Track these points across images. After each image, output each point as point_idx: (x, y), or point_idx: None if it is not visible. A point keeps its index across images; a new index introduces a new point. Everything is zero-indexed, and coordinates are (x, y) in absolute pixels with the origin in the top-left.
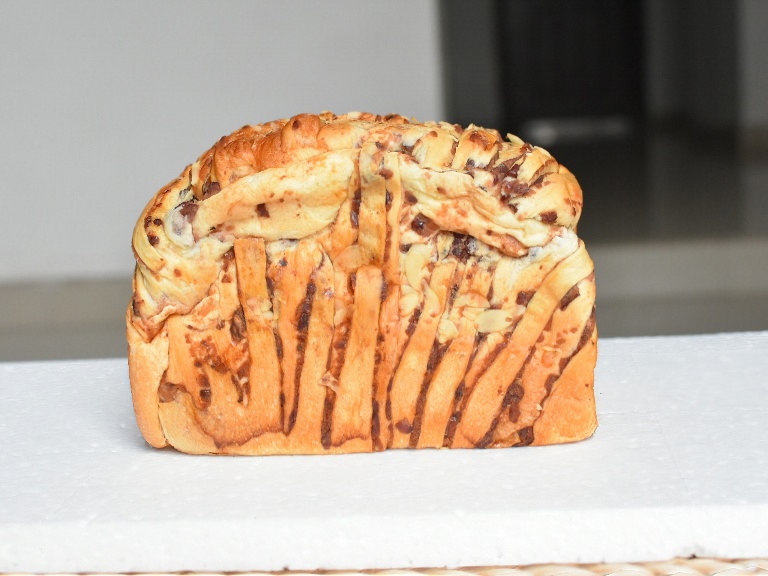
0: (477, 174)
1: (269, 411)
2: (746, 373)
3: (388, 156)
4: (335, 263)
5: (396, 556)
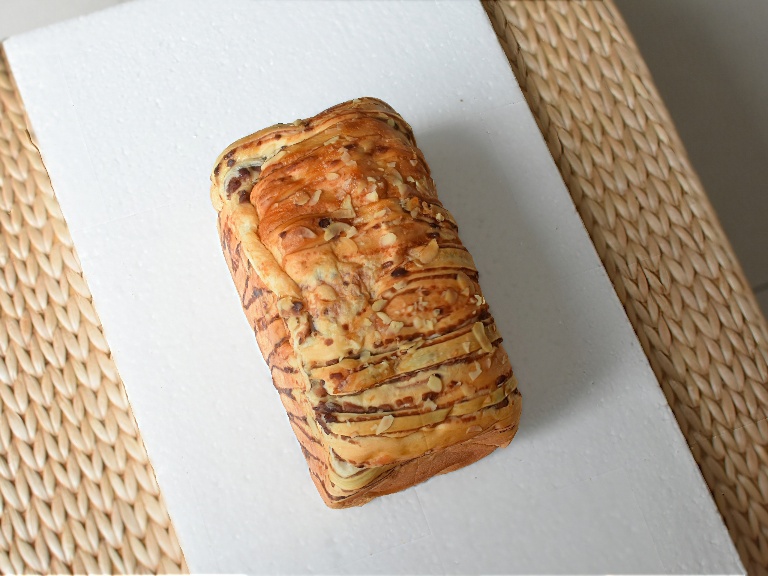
0: (311, 393)
1: None
2: None
3: (290, 320)
4: None
5: None
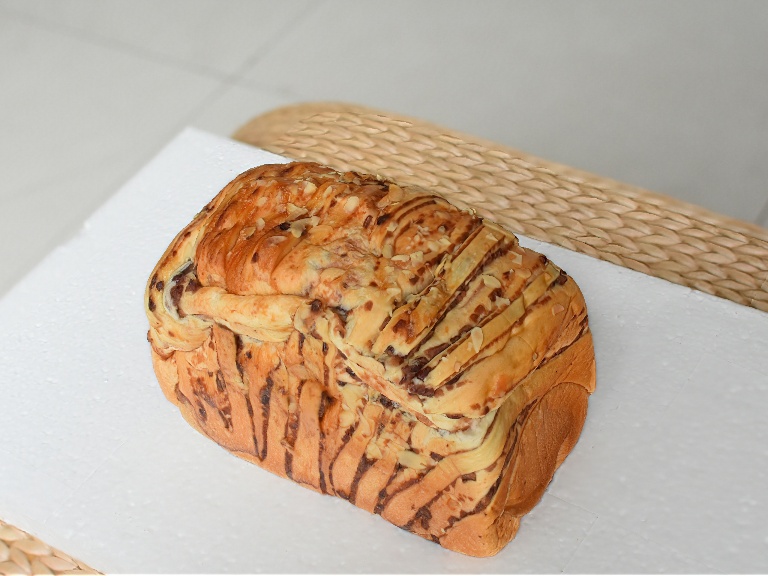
0: (388, 369)
1: (247, 442)
2: (760, 460)
3: (318, 323)
4: (289, 370)
5: None
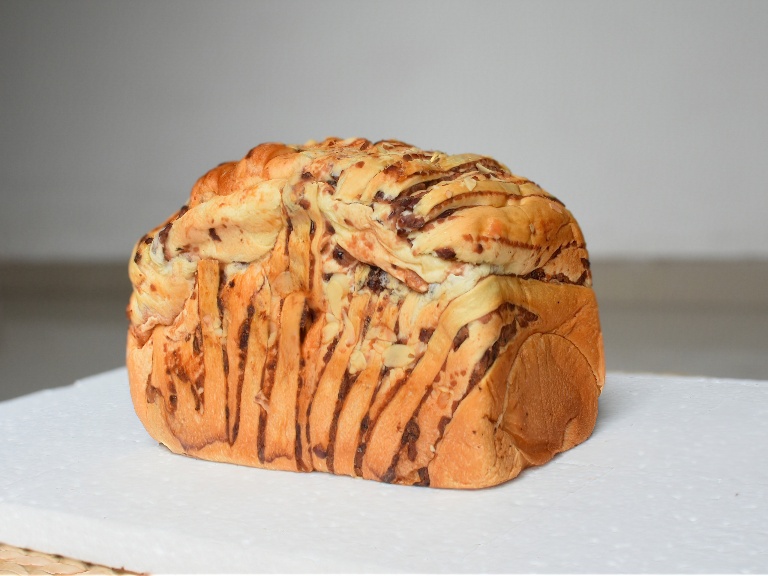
0: (376, 207)
1: (218, 421)
2: None
3: (307, 187)
4: (272, 287)
5: (198, 574)
